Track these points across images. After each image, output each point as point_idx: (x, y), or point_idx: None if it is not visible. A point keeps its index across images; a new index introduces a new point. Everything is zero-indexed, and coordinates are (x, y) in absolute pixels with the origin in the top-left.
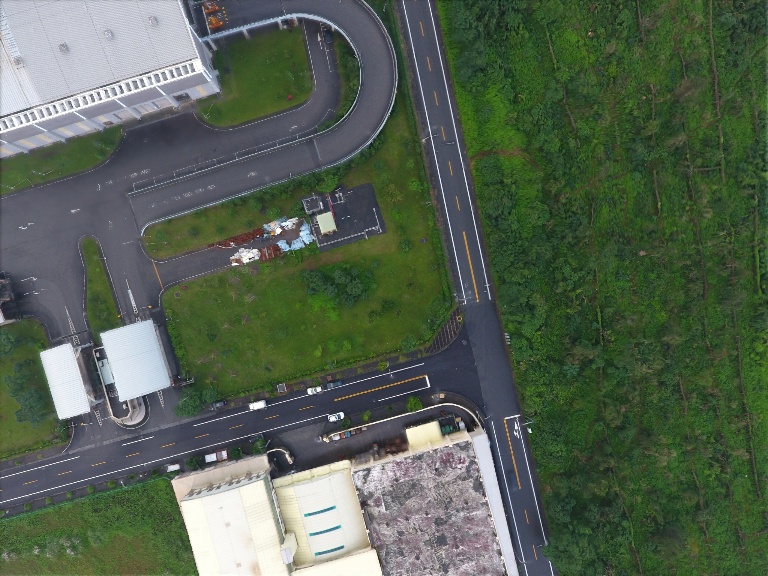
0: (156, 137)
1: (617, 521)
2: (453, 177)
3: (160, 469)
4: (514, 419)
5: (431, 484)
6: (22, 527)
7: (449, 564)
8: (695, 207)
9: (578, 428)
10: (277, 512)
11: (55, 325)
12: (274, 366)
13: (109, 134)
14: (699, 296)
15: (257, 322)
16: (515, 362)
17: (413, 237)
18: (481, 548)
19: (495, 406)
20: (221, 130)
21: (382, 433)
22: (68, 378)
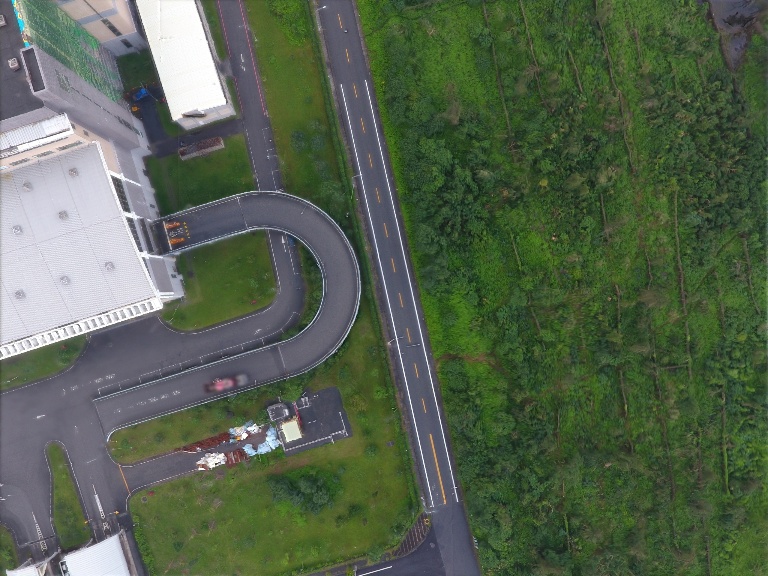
0: (121, 342)
1: None
2: (419, 379)
3: None
4: None
5: None
6: None
7: None
8: (662, 408)
9: None
10: None
11: (22, 531)
12: (242, 571)
13: (74, 339)
14: (666, 501)
15: (224, 527)
16: (483, 568)
17: (379, 440)
18: None
19: None
20: (186, 334)
21: None
22: None
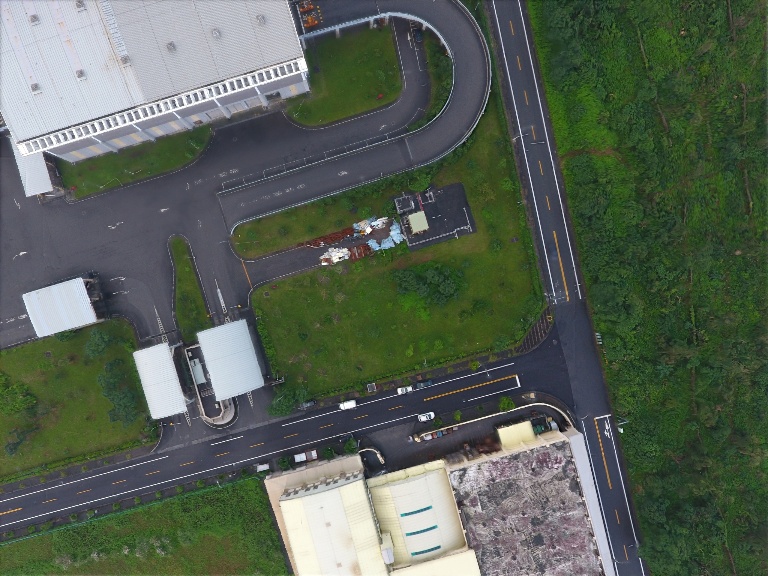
0: (245, 136)
1: (710, 521)
2: (543, 176)
3: (249, 469)
4: (605, 419)
5: (527, 484)
6: (111, 527)
7: (546, 564)
8: None
9: (670, 428)
10: (373, 512)
11: (144, 324)
12: (364, 366)
13: (198, 133)
14: None
15: (347, 322)
16: (607, 362)
17: (503, 236)
18: (578, 548)
19: (585, 406)
20: (310, 129)
21: (472, 433)
22: (164, 378)
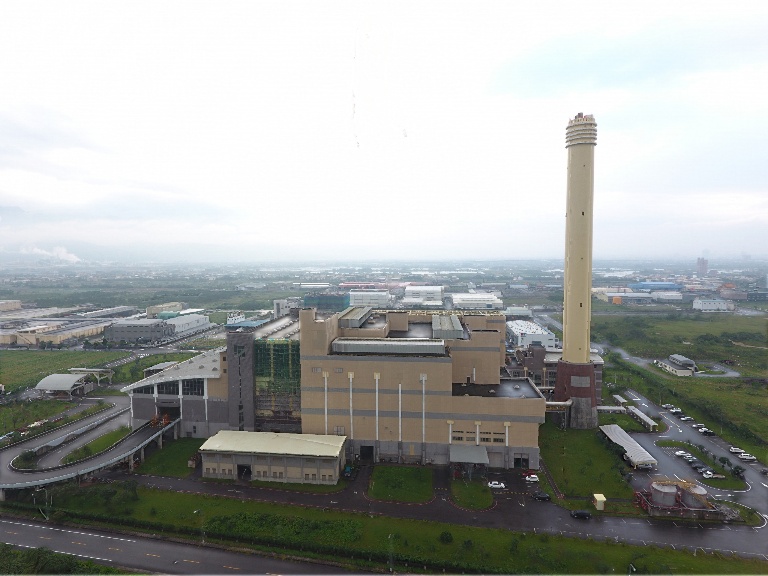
0: None
1: None
2: None
3: None
4: None
5: None
6: None
7: None
8: None
9: None
10: None
11: None
12: None
13: None
14: None
15: None
16: None
17: None
18: None
19: None
20: None
21: None
22: None
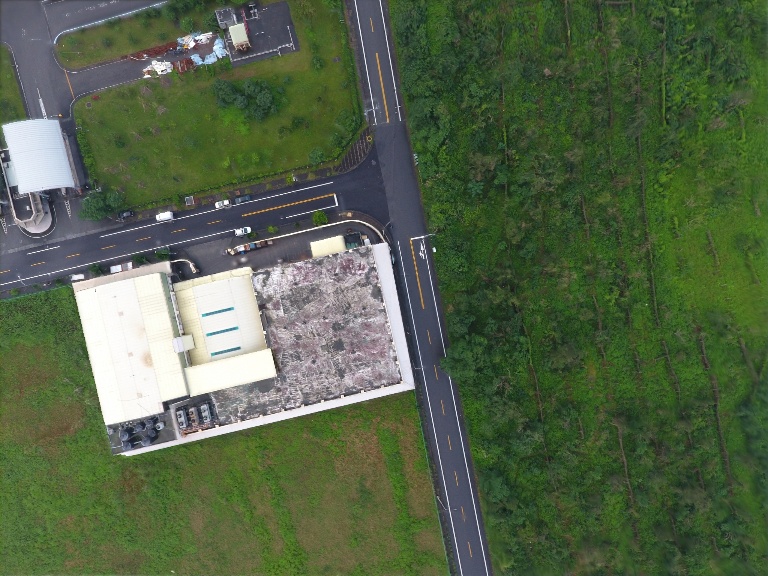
0: None
1: (516, 339)
2: None
3: (64, 279)
4: (420, 240)
5: (330, 289)
6: None
7: (345, 369)
8: (604, 37)
9: (482, 249)
10: (175, 311)
11: None
12: (183, 179)
13: None
14: (604, 121)
15: (167, 134)
16: (421, 180)
17: (326, 56)
18: (377, 354)
19: (402, 227)
20: None
21: (288, 249)
22: None
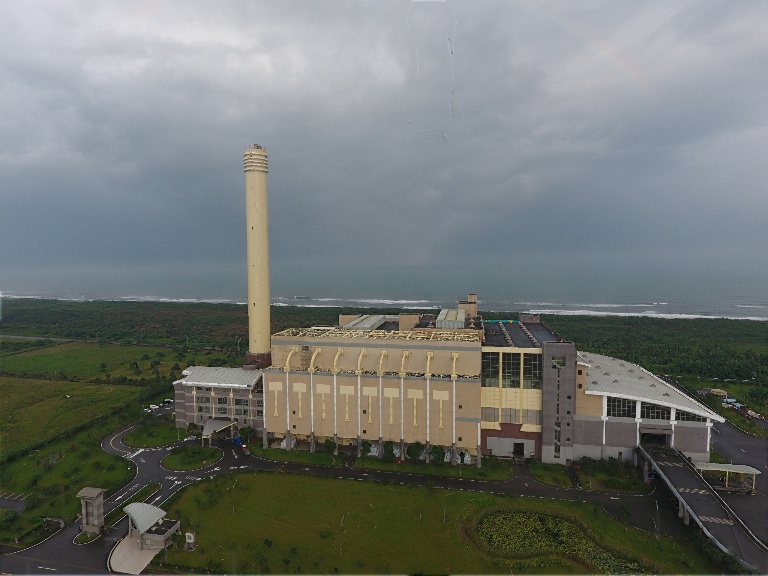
0: None
1: None
2: None
3: None
4: None
5: None
6: None
7: None
8: None
9: None
10: None
11: None
12: None
13: None
14: None
15: None
16: None
17: None
18: None
19: None
20: None
21: None
22: None
